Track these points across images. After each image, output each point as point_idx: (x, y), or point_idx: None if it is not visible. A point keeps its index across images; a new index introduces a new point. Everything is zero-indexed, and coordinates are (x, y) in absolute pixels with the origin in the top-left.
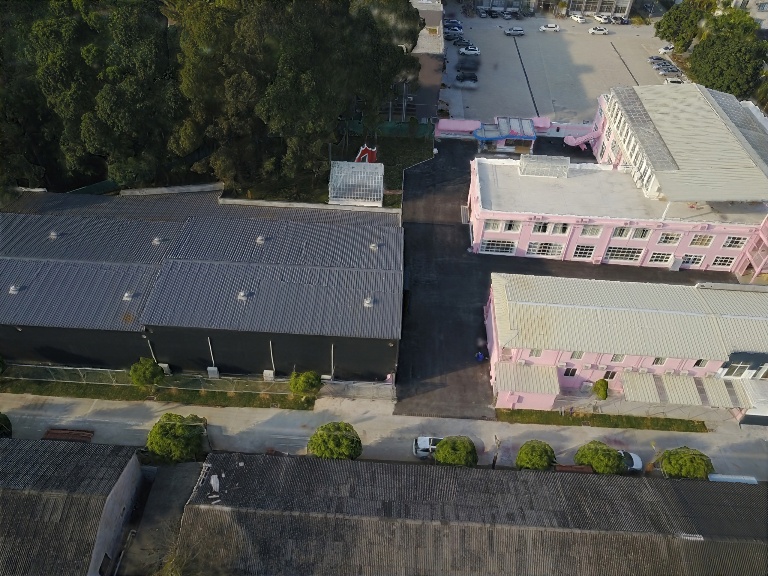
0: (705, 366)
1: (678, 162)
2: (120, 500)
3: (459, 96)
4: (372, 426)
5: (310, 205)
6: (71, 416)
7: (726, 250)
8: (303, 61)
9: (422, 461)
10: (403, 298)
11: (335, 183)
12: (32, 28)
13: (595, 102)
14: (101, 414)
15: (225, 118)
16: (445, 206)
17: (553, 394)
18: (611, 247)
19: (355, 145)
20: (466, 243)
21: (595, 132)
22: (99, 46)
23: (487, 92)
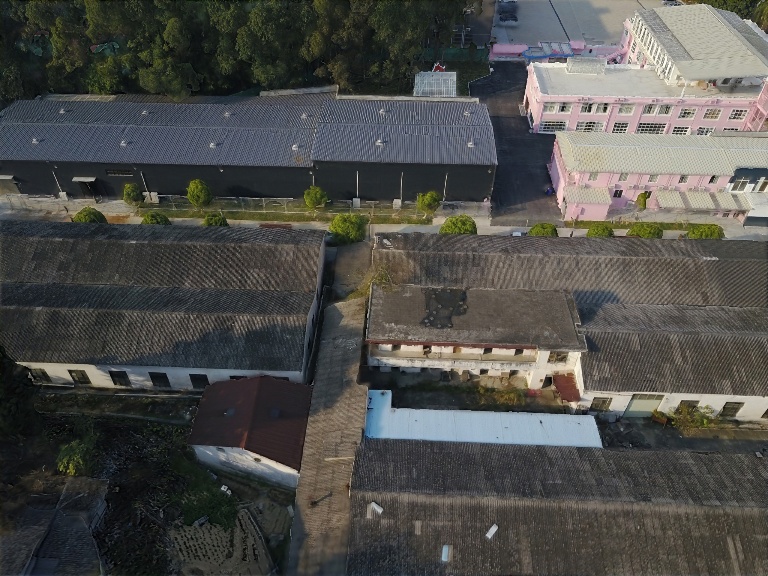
0: (717, 182)
1: (692, 55)
2: None
3: (504, 32)
4: (477, 232)
5: (407, 98)
6: None
7: (731, 122)
8: None
9: None
10: None
11: (419, 89)
12: None
13: (619, 34)
14: None
15: (343, 30)
16: (506, 105)
17: (607, 204)
18: (641, 123)
19: (425, 68)
20: (527, 127)
21: (622, 49)
22: None
23: (527, 29)
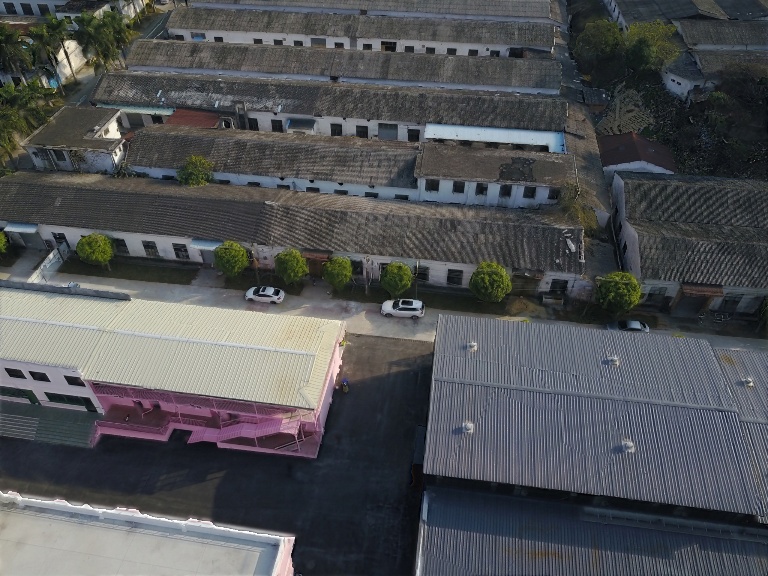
0: None
1: None
2: None
3: None
4: None
5: None
6: None
7: None
8: None
9: None
10: None
11: None
12: None
13: None
14: None
15: None
16: None
17: None
18: None
19: None
20: None
21: None
22: None
23: None
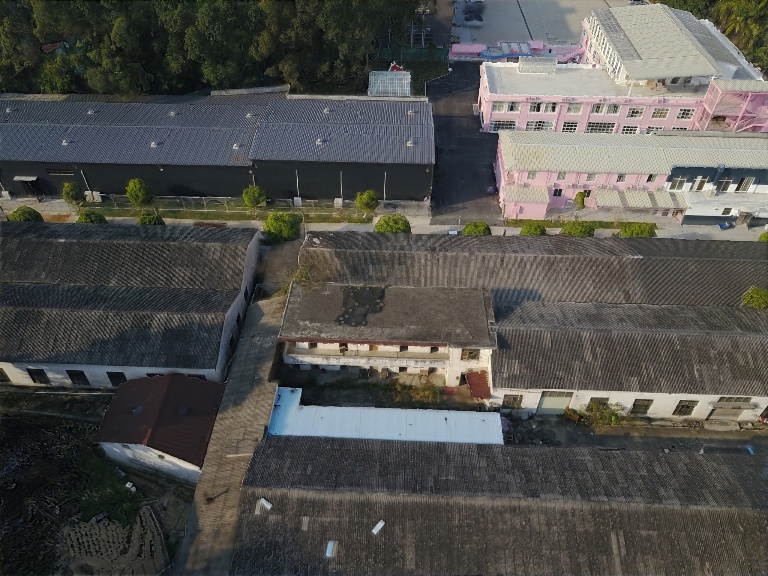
0: (655, 181)
1: (641, 55)
2: (251, 258)
3: (467, 32)
4: (415, 231)
5: (357, 97)
6: None
7: (680, 121)
8: None
9: None
10: None
11: (373, 88)
12: None
13: None
14: None
15: (292, 30)
16: (460, 105)
17: (545, 203)
18: (591, 123)
19: (384, 67)
20: (478, 127)
21: (580, 49)
22: None
23: (491, 29)
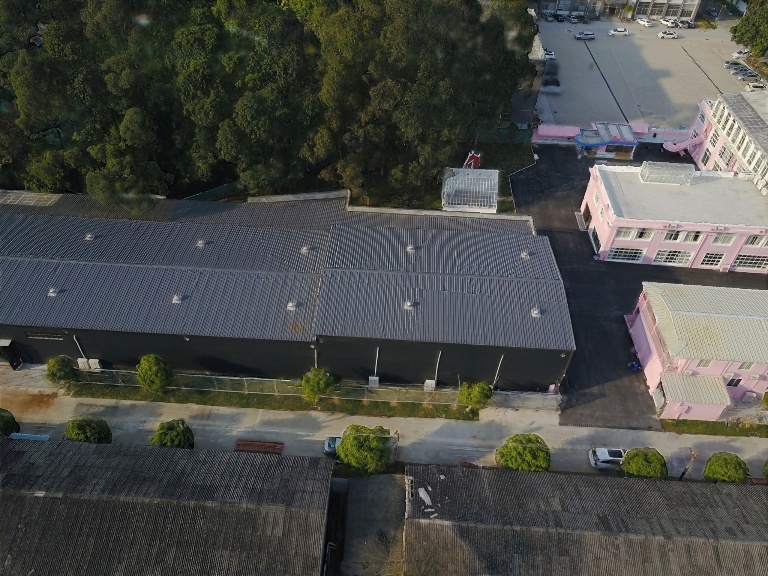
0: None
1: None
2: None
3: (545, 101)
4: (541, 437)
5: (439, 212)
6: (240, 426)
7: None
8: (441, 69)
9: (601, 472)
10: (568, 308)
11: (450, 190)
12: (175, 36)
13: (680, 107)
14: (270, 424)
15: (359, 125)
16: (559, 213)
17: (725, 405)
18: (741, 255)
19: None
20: (590, 250)
21: (697, 138)
22: (238, 53)
23: (571, 97)
